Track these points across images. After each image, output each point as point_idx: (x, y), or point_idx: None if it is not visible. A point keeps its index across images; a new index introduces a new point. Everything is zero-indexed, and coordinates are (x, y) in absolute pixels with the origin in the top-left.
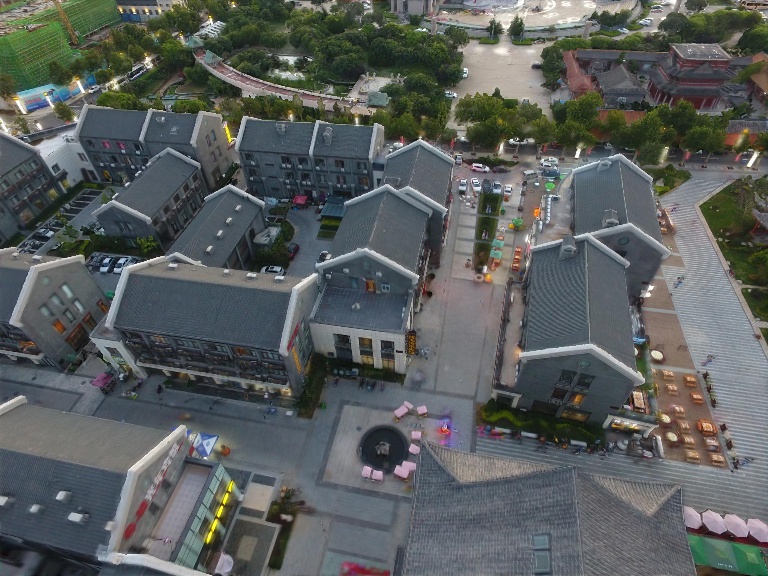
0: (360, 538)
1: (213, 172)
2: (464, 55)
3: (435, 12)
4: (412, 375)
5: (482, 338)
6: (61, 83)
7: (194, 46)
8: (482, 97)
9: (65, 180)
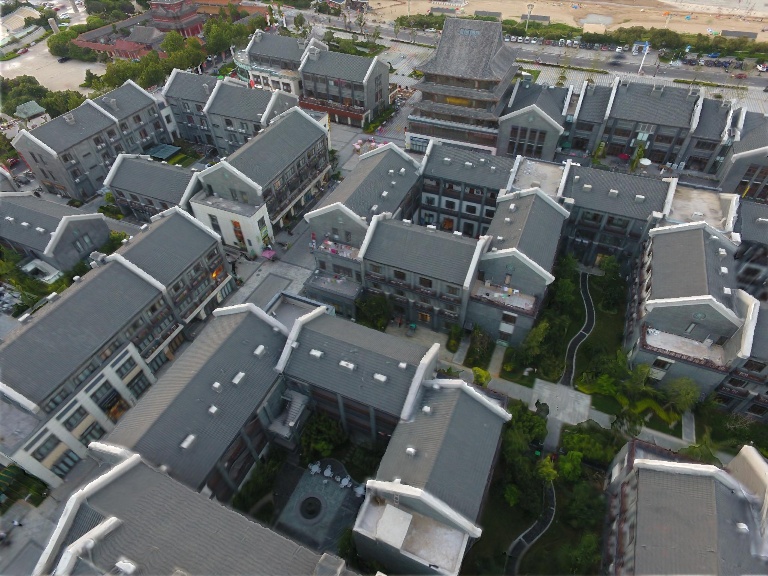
0: None
1: None
2: None
3: None
4: (334, 147)
5: None
6: None
7: None
8: (115, 63)
9: None
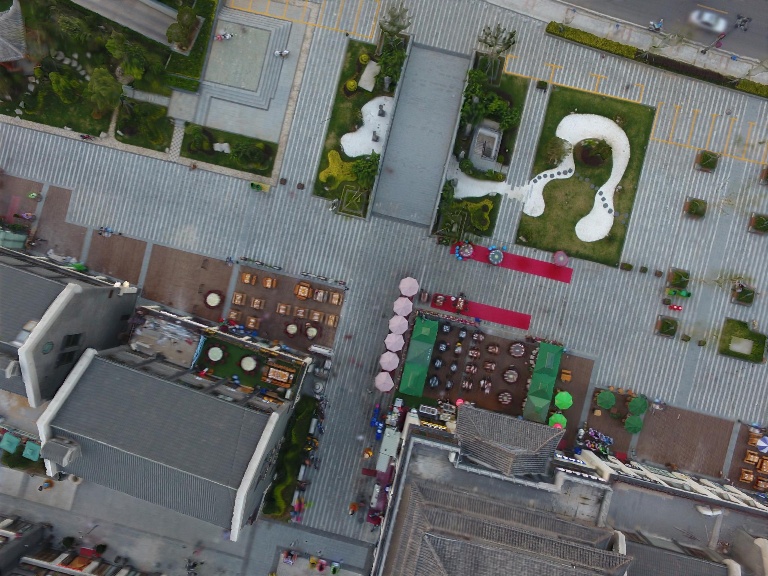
0: None
1: None
2: None
3: None
4: None
5: None
6: None
7: None
8: None
9: None
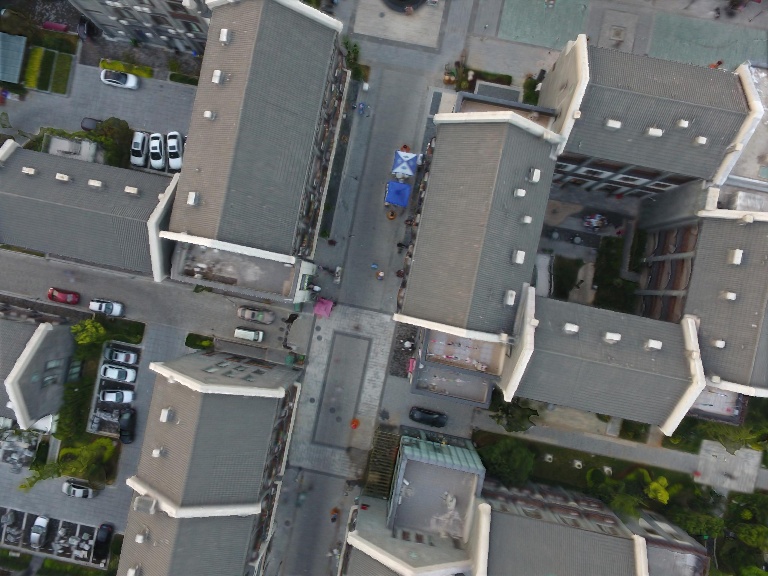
0: (488, 8)
1: None
2: None
3: None
4: None
5: None
6: None
7: None
8: None
9: None
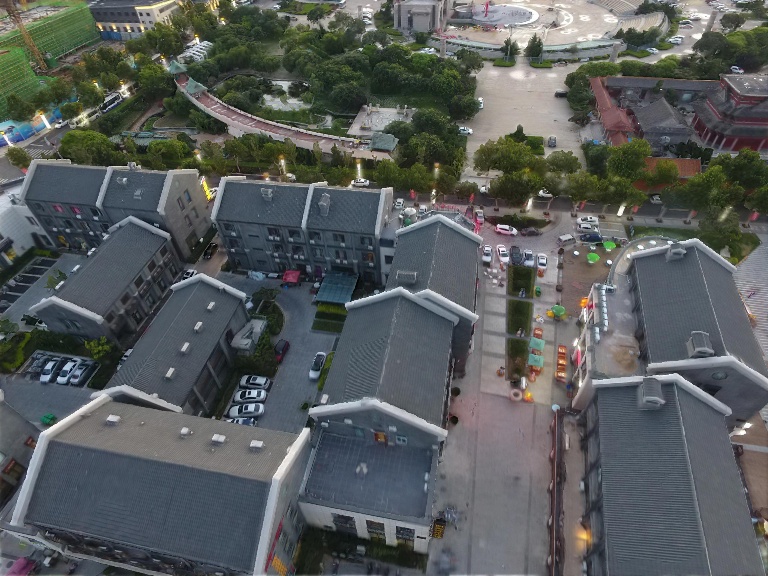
0: None
1: (188, 239)
2: (477, 80)
3: (442, 28)
4: (437, 555)
5: (526, 492)
6: (22, 119)
7: (176, 72)
8: (506, 143)
9: (11, 249)
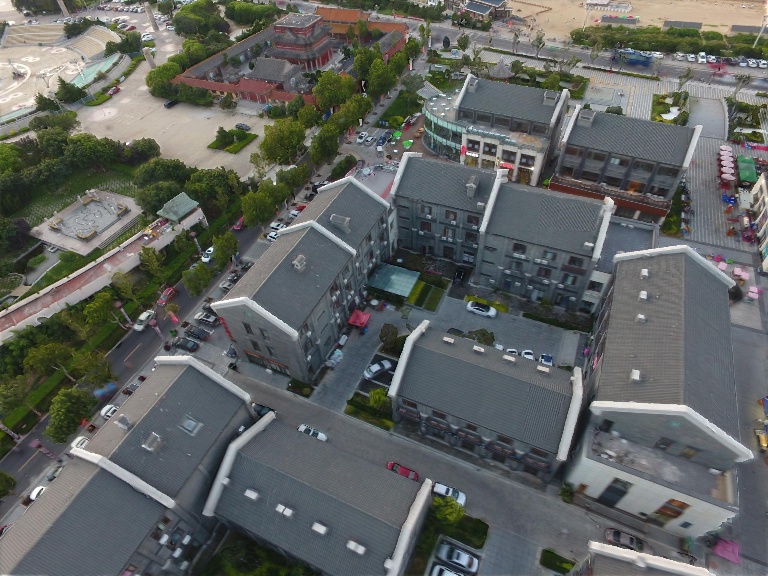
0: None
1: None
2: None
3: None
4: None
5: None
6: None
7: None
8: (275, 126)
9: None
